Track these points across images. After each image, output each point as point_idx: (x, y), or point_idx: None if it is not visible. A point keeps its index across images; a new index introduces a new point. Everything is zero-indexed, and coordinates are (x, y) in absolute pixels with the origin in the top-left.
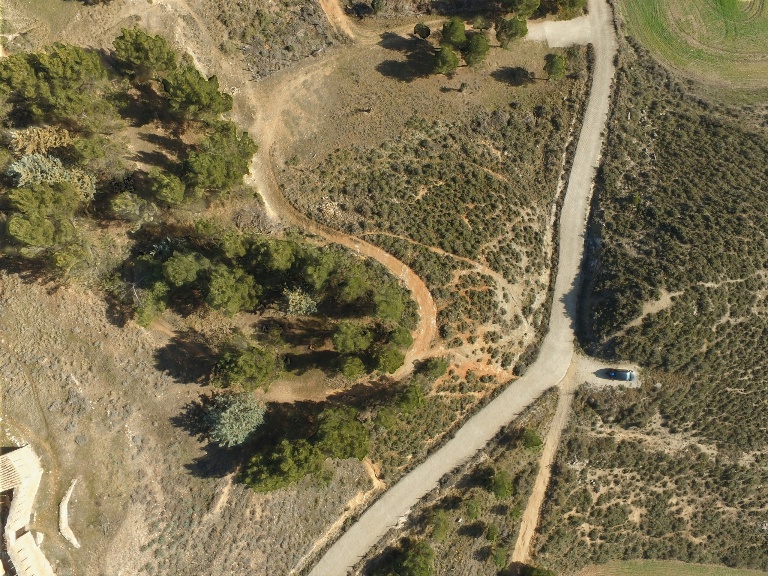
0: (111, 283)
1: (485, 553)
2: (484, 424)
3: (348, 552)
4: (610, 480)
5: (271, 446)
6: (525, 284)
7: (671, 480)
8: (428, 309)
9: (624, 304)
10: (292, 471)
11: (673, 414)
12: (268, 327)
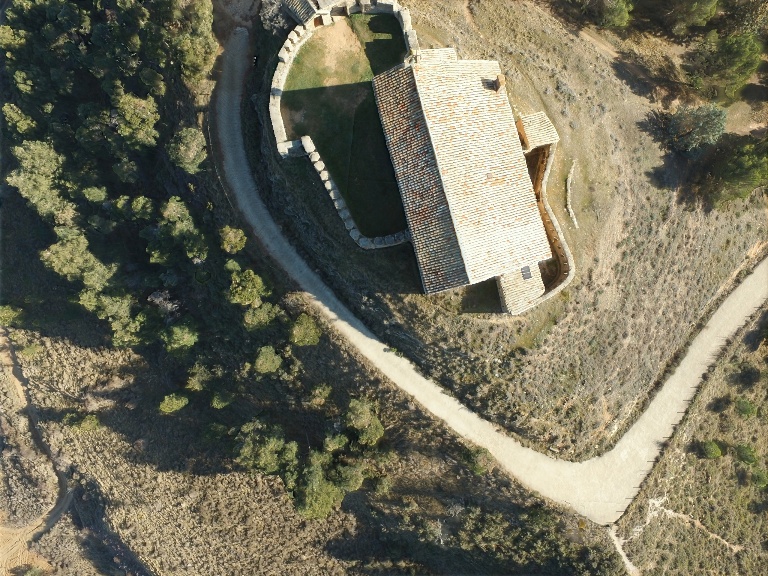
0: None
1: None
2: None
3: (745, 302)
4: None
5: (703, 173)
6: None
7: None
8: None
9: None
10: None
11: None
12: (695, 59)
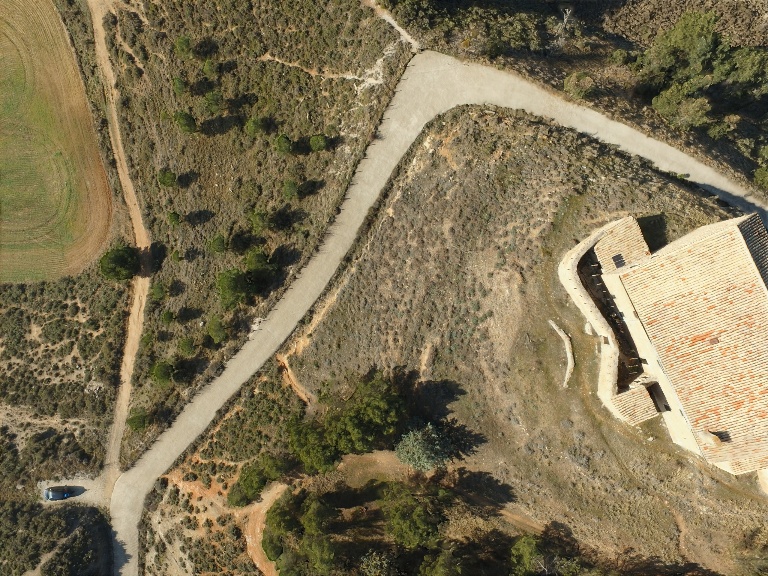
0: (571, 569)
1: (175, 288)
2: (189, 428)
3: (303, 292)
4: (63, 369)
5: None
6: (166, 575)
7: (4, 371)
8: (256, 551)
9: (61, 575)
10: (350, 428)
11: (4, 452)
12: None
